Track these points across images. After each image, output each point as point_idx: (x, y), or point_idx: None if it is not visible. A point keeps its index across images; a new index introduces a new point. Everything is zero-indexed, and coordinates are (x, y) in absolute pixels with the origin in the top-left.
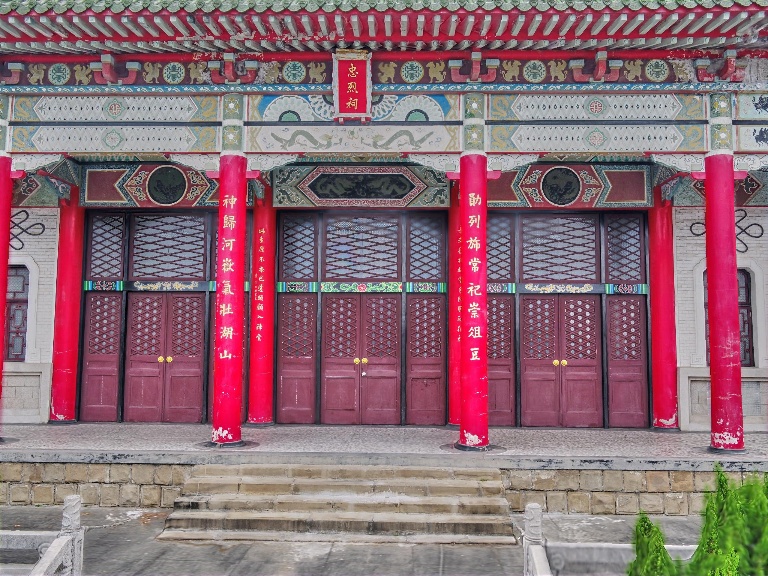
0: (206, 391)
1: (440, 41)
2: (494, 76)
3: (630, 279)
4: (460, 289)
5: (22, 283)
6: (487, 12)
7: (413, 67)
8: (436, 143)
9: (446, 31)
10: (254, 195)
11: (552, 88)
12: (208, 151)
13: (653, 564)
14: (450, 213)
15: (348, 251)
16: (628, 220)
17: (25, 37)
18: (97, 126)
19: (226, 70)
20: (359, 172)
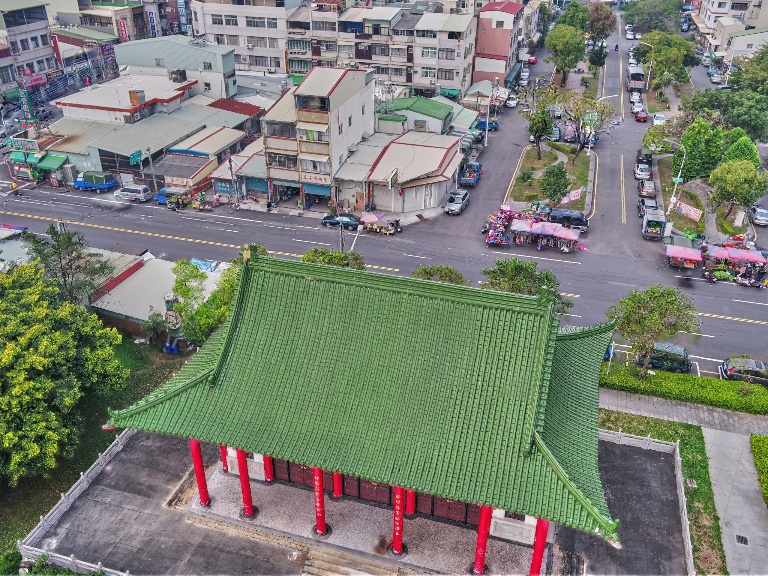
0: None
1: None
2: None
3: None
4: None
5: None
6: None
7: None
8: None
9: None
10: None
11: None
12: None
13: None
14: None
15: None
16: None
17: None
18: None
19: None
20: None
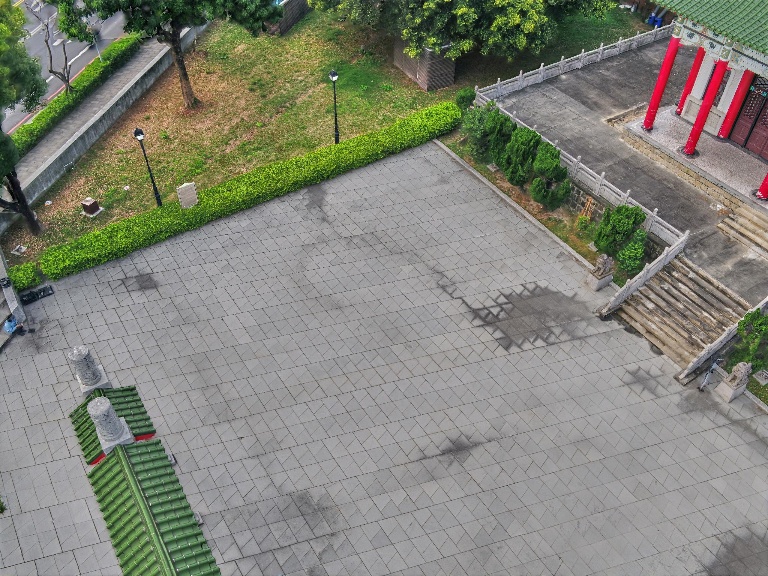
0: None
1: None
2: None
3: None
4: None
5: (727, 74)
6: None
7: None
8: None
9: None
10: None
11: None
12: None
13: (751, 314)
14: None
15: None
16: None
17: None
18: (763, 65)
19: None
20: None
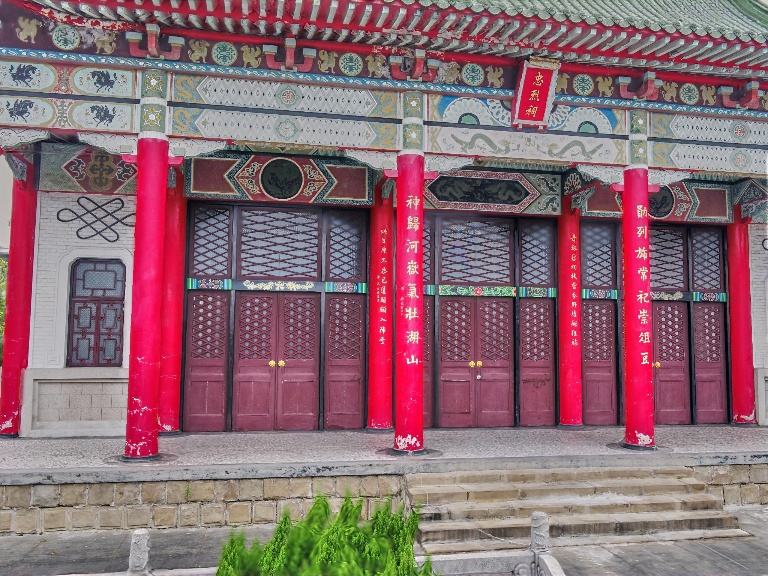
0: (323, 397)
1: (633, 59)
2: (657, 95)
3: (712, 288)
4: (573, 295)
5: (113, 279)
6: (697, 37)
7: (584, 80)
8: (605, 155)
9: (646, 50)
10: (374, 194)
11: (707, 111)
12: (388, 149)
13: None
14: (561, 221)
15: (463, 254)
16: (709, 234)
17: (218, 11)
18: (269, 114)
19: (418, 67)
20: (477, 176)
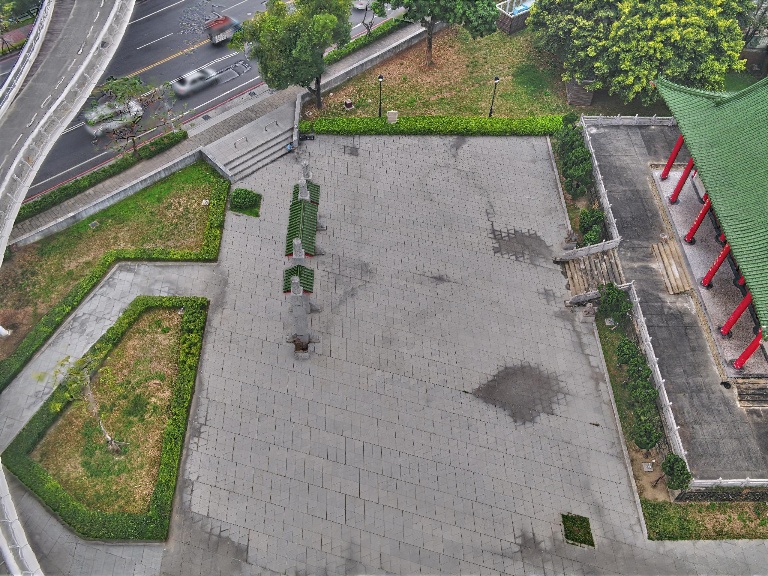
0: None
1: None
2: None
3: None
4: None
5: None
6: None
7: None
8: None
9: None
10: None
11: None
12: None
13: None
14: None
15: None
16: None
17: None
18: None
19: None
20: None
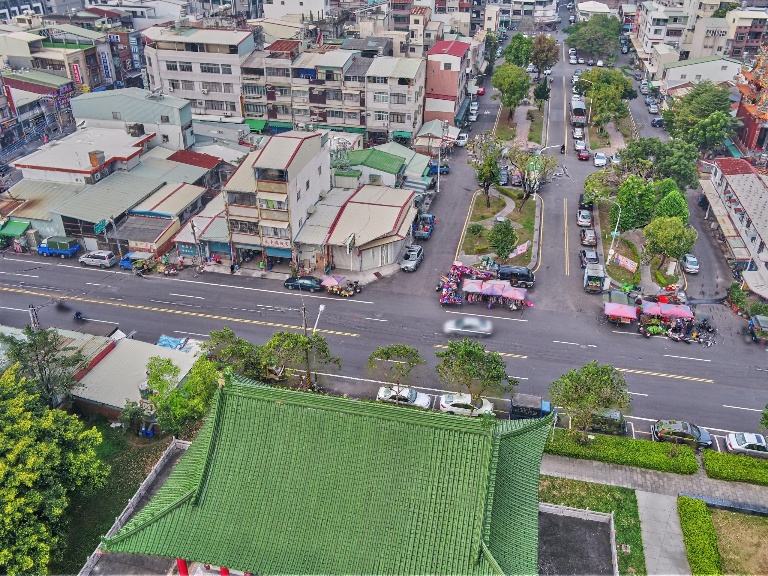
0: None
1: None
2: None
3: None
4: None
5: None
6: None
7: None
8: None
9: None
10: None
11: None
12: None
13: None
14: None
15: None
16: None
17: None
18: None
19: None
20: None
